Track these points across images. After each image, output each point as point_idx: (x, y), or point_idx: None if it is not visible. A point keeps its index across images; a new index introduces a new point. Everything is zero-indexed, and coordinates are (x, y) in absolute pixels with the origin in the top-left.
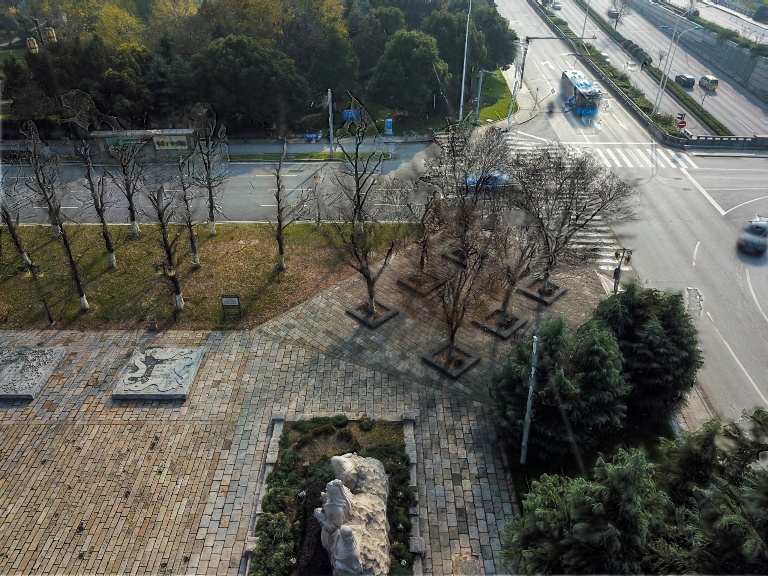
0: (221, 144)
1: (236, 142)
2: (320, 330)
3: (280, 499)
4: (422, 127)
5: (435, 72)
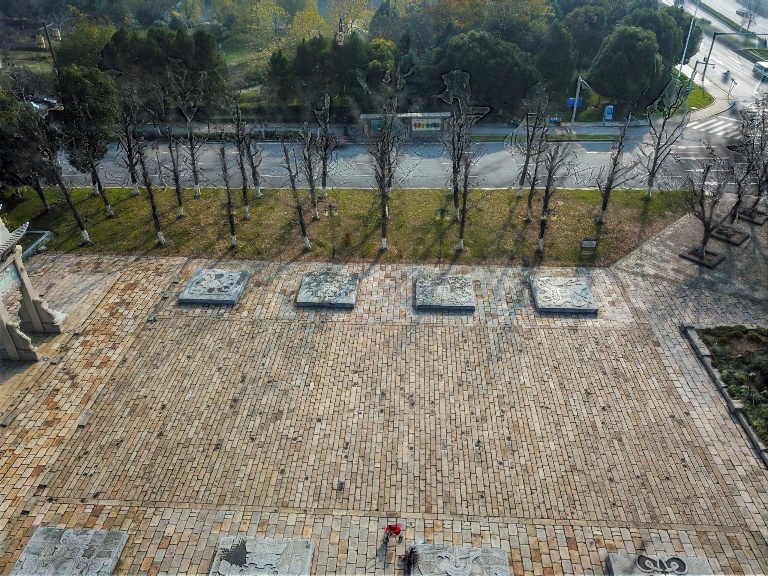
0: (545, 118)
1: (472, 126)
2: (668, 268)
3: (739, 377)
4: (635, 113)
5: (655, 63)
